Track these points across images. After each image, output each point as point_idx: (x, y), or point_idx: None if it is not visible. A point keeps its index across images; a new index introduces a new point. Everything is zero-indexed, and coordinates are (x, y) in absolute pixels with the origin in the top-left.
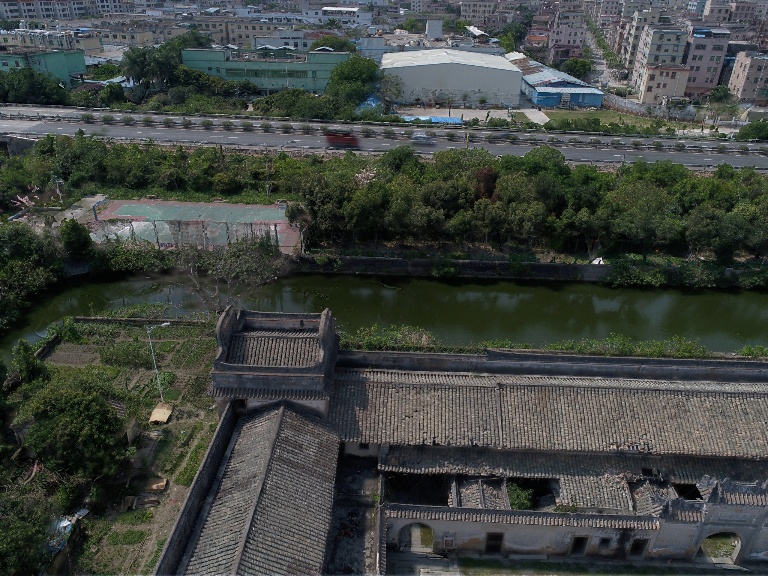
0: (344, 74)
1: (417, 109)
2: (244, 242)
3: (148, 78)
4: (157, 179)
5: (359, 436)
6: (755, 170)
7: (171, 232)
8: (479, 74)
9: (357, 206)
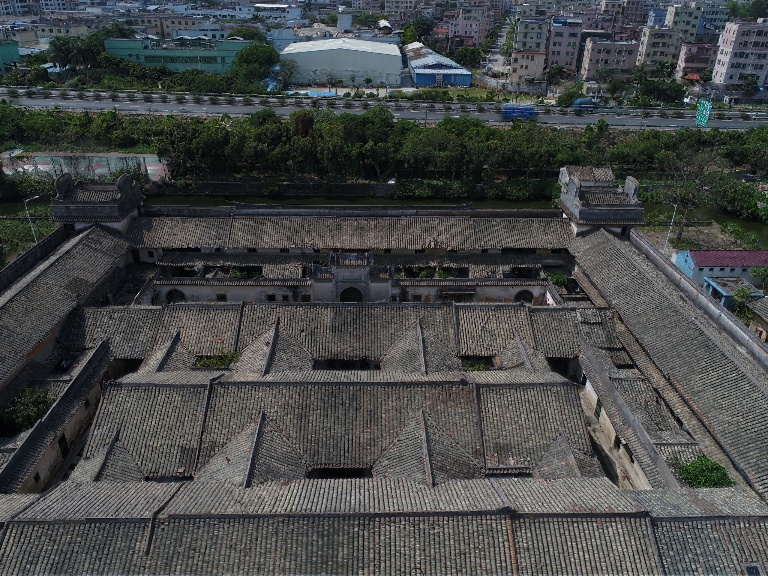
0: (243, 58)
1: (311, 89)
2: (120, 171)
3: (72, 63)
4: (66, 137)
5: (143, 244)
6: (544, 124)
7: (65, 165)
8: (364, 58)
9: (202, 142)
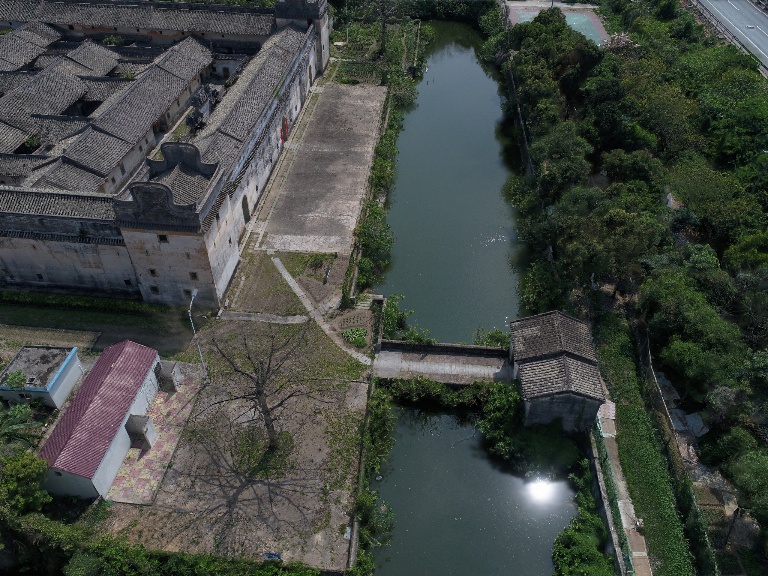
0: None
1: None
2: (502, 33)
3: None
4: None
5: None
6: None
7: None
8: None
9: (515, 28)
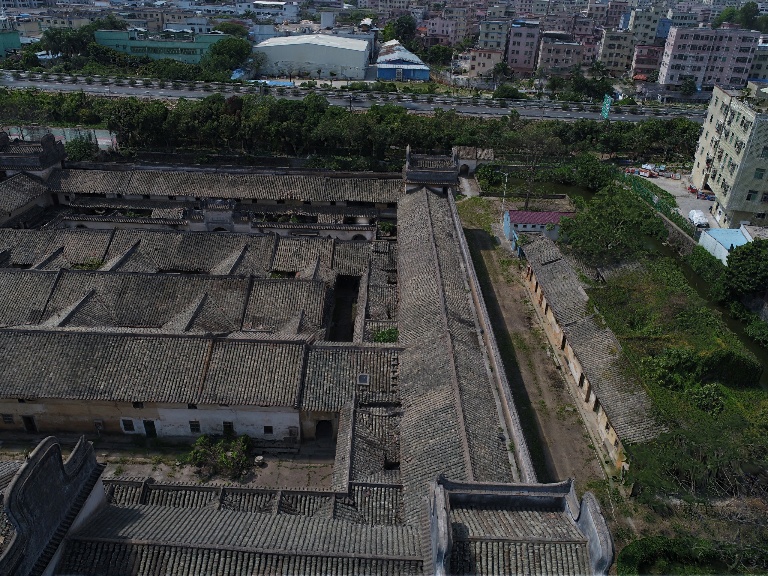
0: (216, 50)
1: (280, 79)
2: (74, 141)
3: (63, 52)
4: (41, 114)
5: (59, 189)
6: (466, 114)
7: (29, 135)
8: (330, 53)
9: (142, 117)
